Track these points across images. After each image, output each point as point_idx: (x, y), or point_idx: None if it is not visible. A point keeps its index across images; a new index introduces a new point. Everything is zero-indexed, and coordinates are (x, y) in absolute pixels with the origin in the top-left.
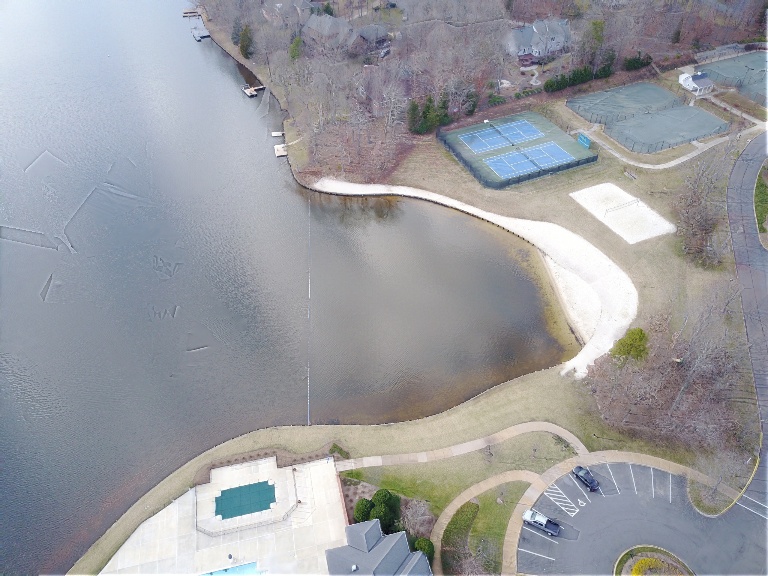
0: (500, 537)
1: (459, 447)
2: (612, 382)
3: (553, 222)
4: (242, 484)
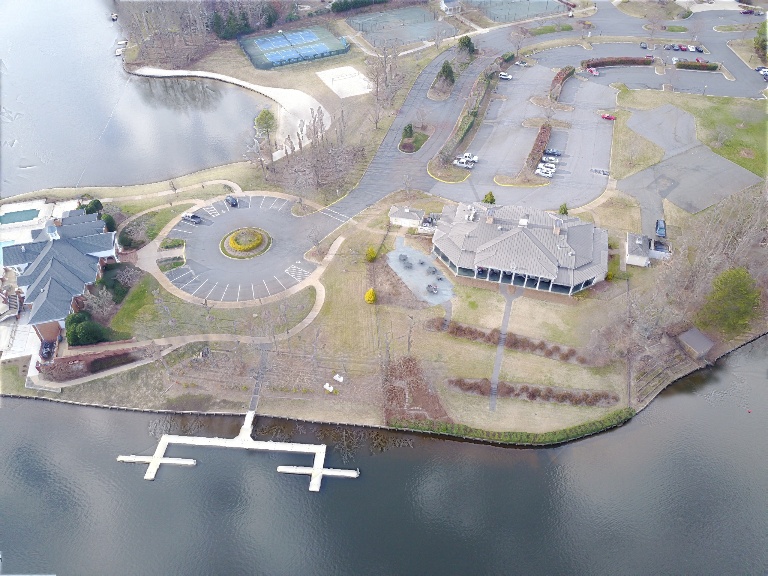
0: (163, 224)
1: (164, 192)
2: (254, 146)
3: (297, 89)
4: (19, 210)
